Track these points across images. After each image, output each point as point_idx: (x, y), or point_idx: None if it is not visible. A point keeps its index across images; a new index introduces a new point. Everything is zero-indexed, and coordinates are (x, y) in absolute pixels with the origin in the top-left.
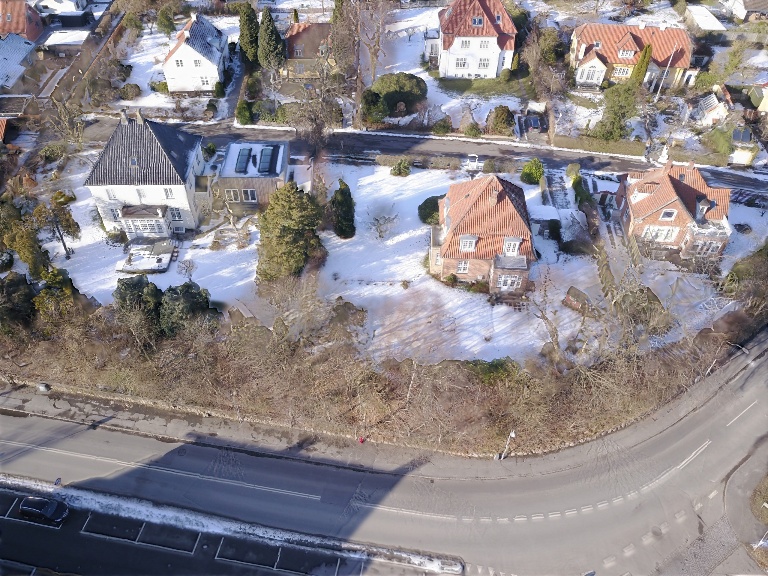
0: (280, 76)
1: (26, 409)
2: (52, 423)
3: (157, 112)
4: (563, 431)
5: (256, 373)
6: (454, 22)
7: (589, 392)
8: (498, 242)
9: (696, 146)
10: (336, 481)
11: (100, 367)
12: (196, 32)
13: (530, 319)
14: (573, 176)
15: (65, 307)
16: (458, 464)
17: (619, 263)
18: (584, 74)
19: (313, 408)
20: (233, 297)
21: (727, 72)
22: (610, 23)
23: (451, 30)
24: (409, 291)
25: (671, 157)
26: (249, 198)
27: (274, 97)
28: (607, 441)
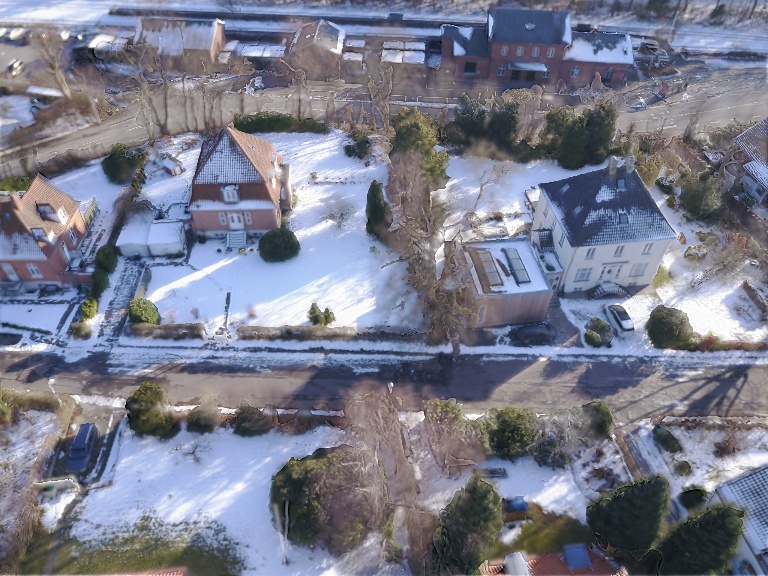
0: None
1: None
2: None
3: (759, 439)
4: None
5: None
6: None
7: None
8: None
9: None
10: (353, 118)
11: None
12: None
13: None
14: None
15: None
16: None
17: None
18: None
19: None
20: (455, 171)
21: None
22: None
23: None
24: None
25: None
26: None
27: None
28: None
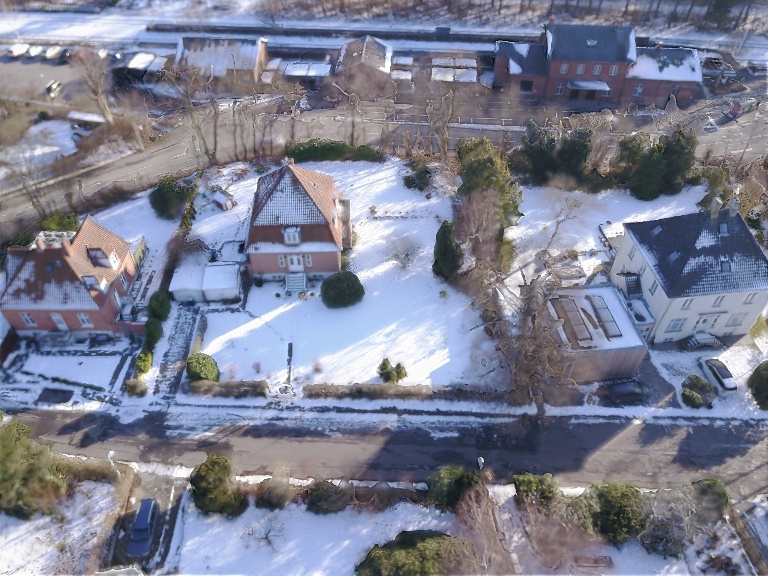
0: None
1: None
2: None
3: None
4: None
5: None
6: None
7: None
8: None
9: None
10: None
11: None
12: None
13: None
14: None
15: None
16: None
17: None
18: None
19: None
20: (521, 204)
21: None
22: None
23: None
24: None
25: None
26: None
27: None
28: None
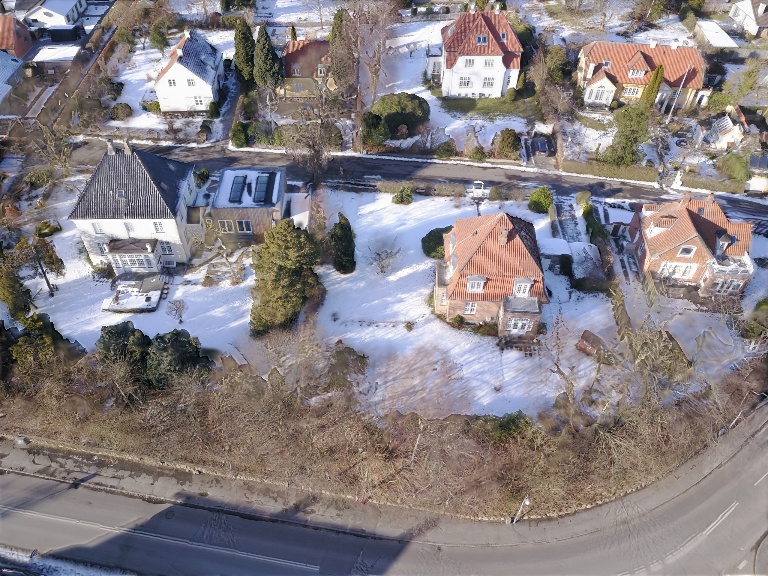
0: (277, 95)
1: (3, 465)
2: (31, 481)
3: (149, 134)
4: (579, 492)
5: (250, 426)
6: (458, 40)
7: (608, 453)
8: (508, 283)
9: (710, 171)
10: (336, 548)
11: (82, 421)
12: (189, 50)
13: (542, 366)
14: (583, 204)
15: (45, 357)
16: (467, 528)
17: (634, 301)
18: (593, 94)
19: (311, 465)
20: (226, 340)
21: (741, 93)
22: (618, 39)
23: (454, 48)
24: (413, 334)
25: (685, 183)
26: (244, 229)
27: (270, 118)
28: (626, 502)
